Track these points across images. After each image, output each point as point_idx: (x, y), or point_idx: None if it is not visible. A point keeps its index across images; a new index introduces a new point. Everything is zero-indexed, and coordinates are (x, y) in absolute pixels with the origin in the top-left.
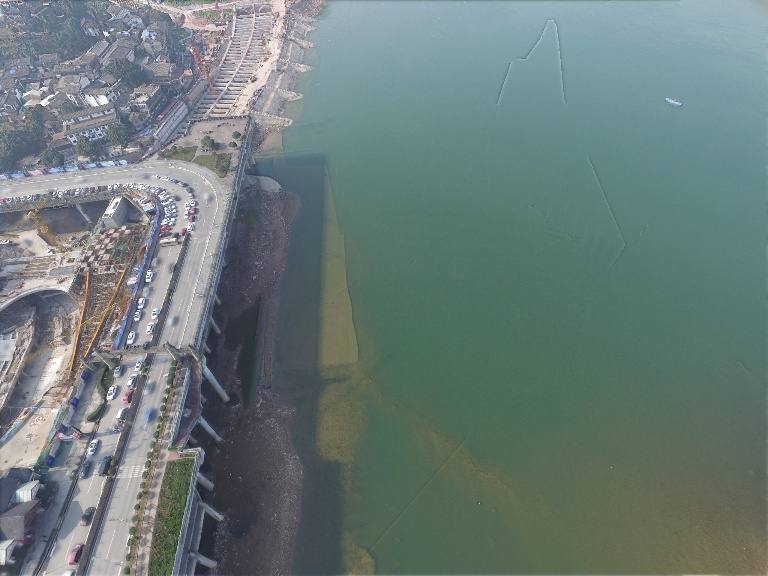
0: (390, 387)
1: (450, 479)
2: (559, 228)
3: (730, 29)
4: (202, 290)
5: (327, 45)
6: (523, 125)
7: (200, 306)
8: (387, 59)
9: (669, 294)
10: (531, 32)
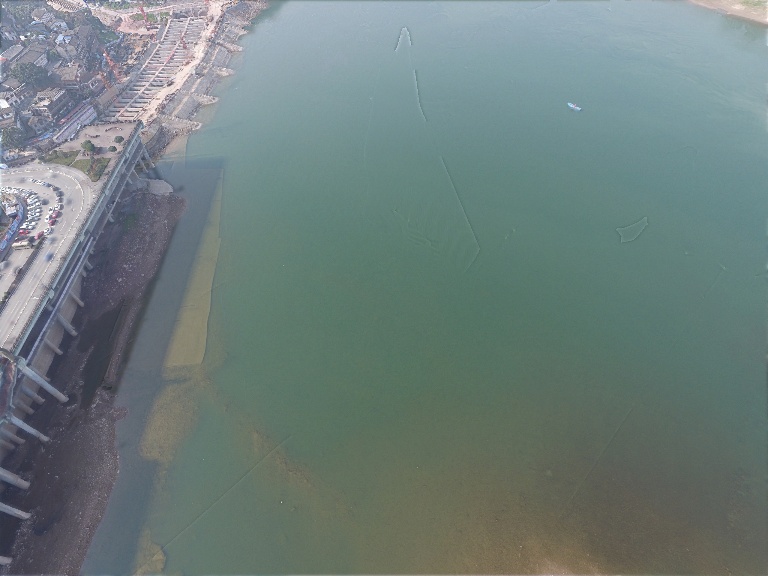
0: (227, 388)
1: (260, 478)
2: (419, 232)
3: (651, 34)
4: (39, 293)
5: (256, 49)
6: (388, 131)
7: (32, 309)
8: (310, 63)
9: (525, 297)
10: (456, 36)
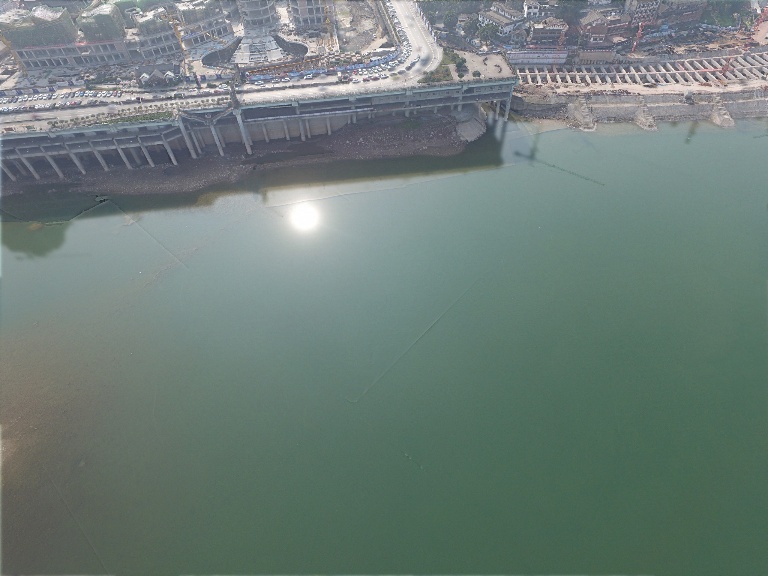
0: (240, 226)
1: (161, 257)
2: None
3: None
4: None
5: None
6: None
7: None
8: None
9: (317, 481)
10: None
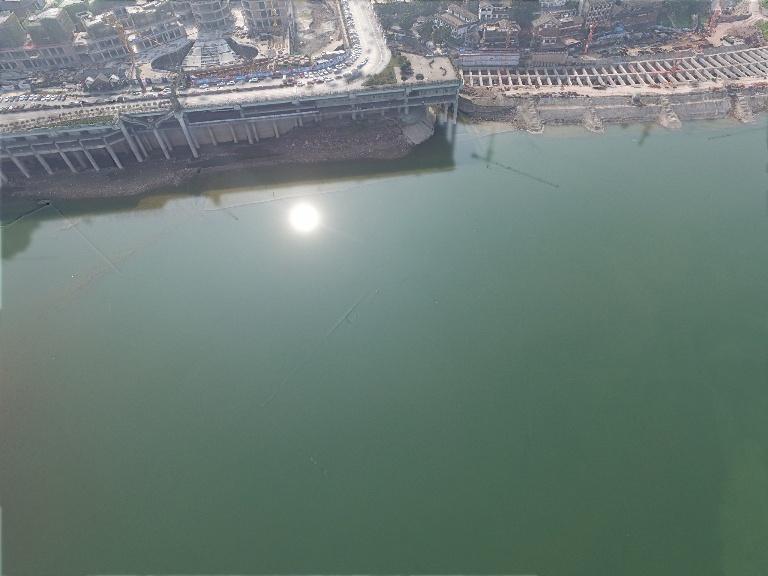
0: (178, 230)
1: (95, 262)
2: None
3: None
4: None
5: (761, 134)
6: (406, 252)
7: None
8: (747, 192)
9: (225, 486)
10: None
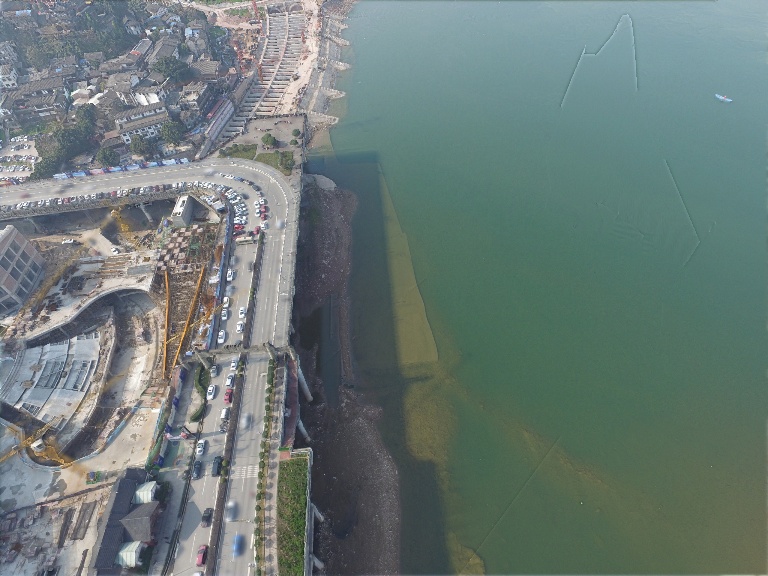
0: (474, 386)
1: (549, 479)
2: (631, 225)
3: None
4: (286, 289)
5: (363, 43)
6: (592, 121)
7: (287, 305)
8: (426, 57)
9: (743, 291)
10: (569, 29)
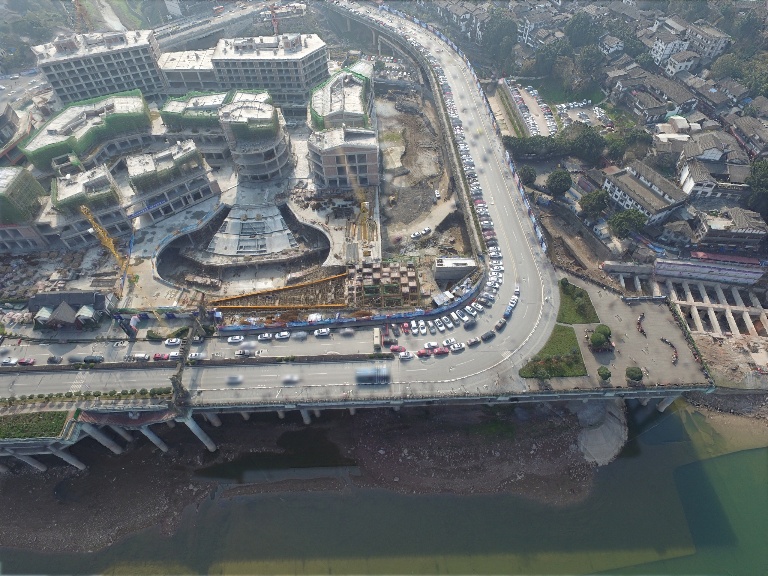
0: None
1: None
2: None
3: None
4: (286, 395)
5: None
6: None
7: (259, 398)
8: None
9: None
10: None
